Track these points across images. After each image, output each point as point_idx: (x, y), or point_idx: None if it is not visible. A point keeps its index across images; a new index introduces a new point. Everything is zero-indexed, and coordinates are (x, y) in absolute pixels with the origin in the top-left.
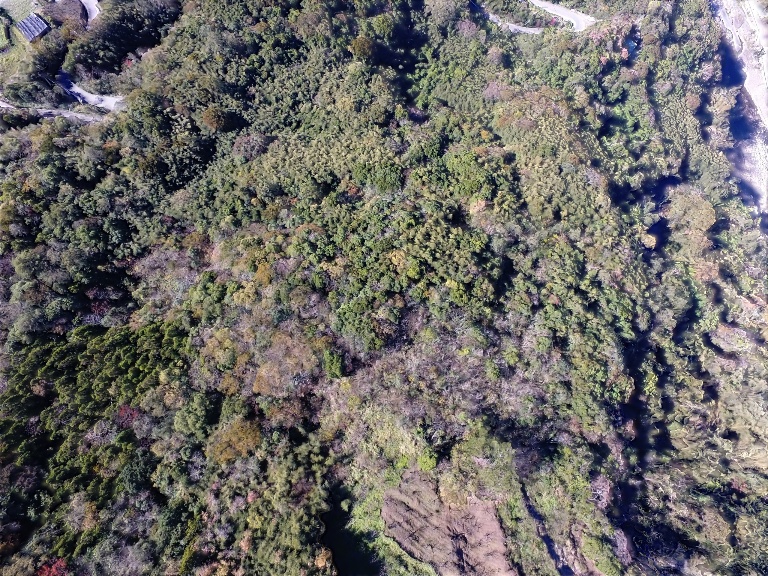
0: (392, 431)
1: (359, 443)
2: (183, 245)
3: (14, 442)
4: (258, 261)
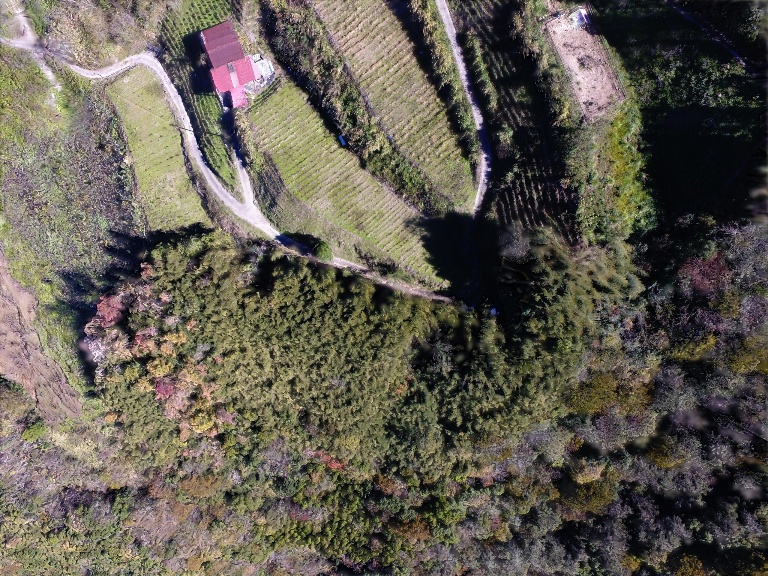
0: (74, 450)
1: (106, 448)
2: (288, 574)
3: (386, 528)
4: (202, 570)
